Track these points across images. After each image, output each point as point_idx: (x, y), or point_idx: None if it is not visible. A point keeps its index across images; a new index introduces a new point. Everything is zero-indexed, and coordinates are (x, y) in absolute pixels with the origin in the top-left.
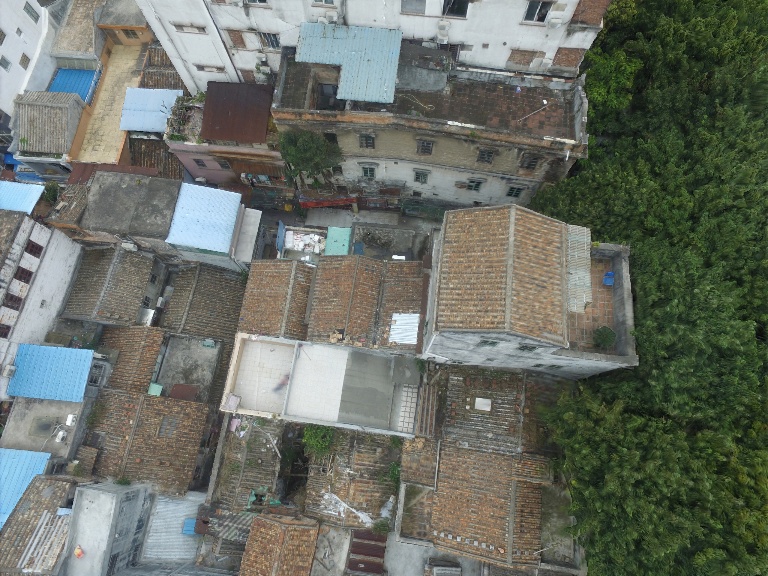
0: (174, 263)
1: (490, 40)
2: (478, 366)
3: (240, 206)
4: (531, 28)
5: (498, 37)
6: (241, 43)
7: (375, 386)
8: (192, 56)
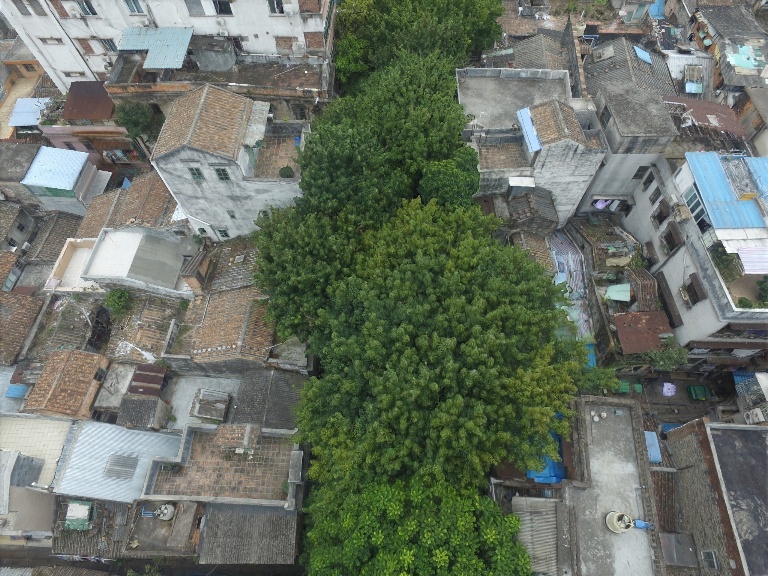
0: (39, 215)
1: (257, 31)
2: (241, 236)
3: (91, 166)
4: (278, 19)
5: (261, 28)
6: (90, 50)
7: (165, 260)
8: (59, 64)
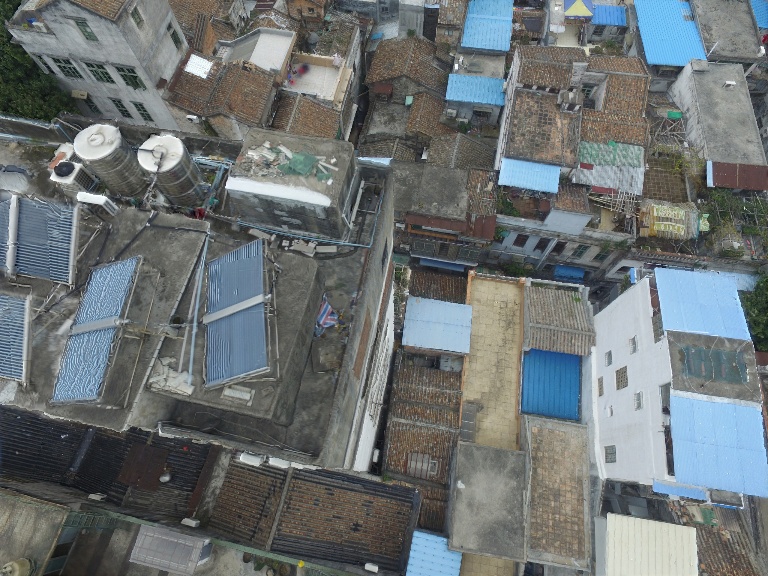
0: None
1: None
2: None
3: None
4: None
5: None
6: None
7: None
8: None
